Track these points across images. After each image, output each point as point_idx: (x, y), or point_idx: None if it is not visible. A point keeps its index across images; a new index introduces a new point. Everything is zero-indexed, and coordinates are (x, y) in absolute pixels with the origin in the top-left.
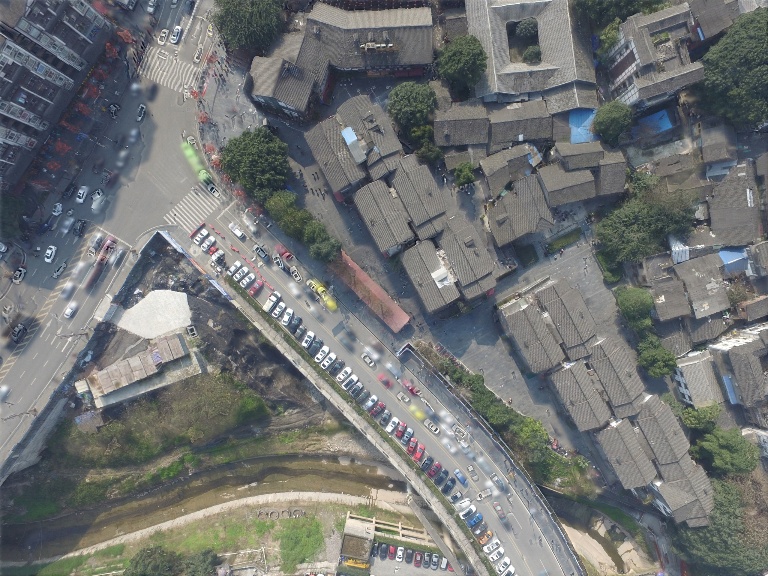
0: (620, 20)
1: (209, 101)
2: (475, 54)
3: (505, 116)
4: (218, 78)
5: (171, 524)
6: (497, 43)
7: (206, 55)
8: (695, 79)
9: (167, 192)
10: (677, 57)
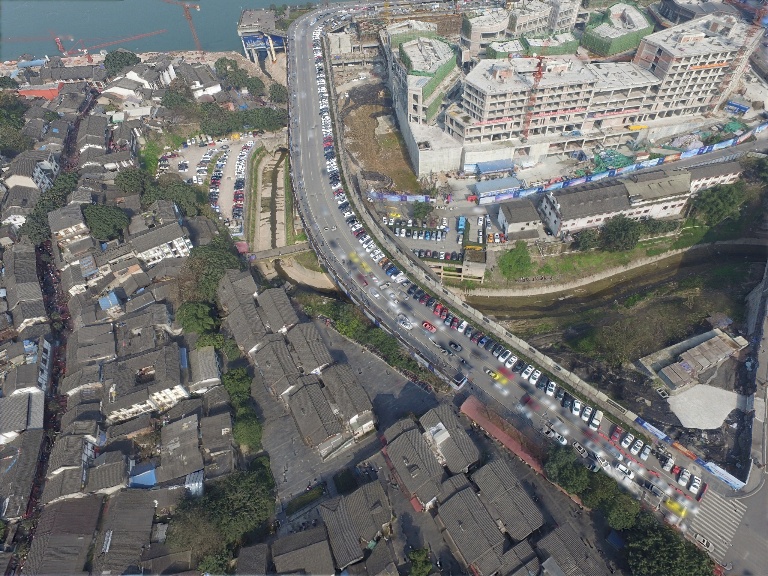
0: None
1: None
2: None
3: None
4: None
5: (617, 270)
6: None
7: None
8: None
9: (759, 539)
10: None
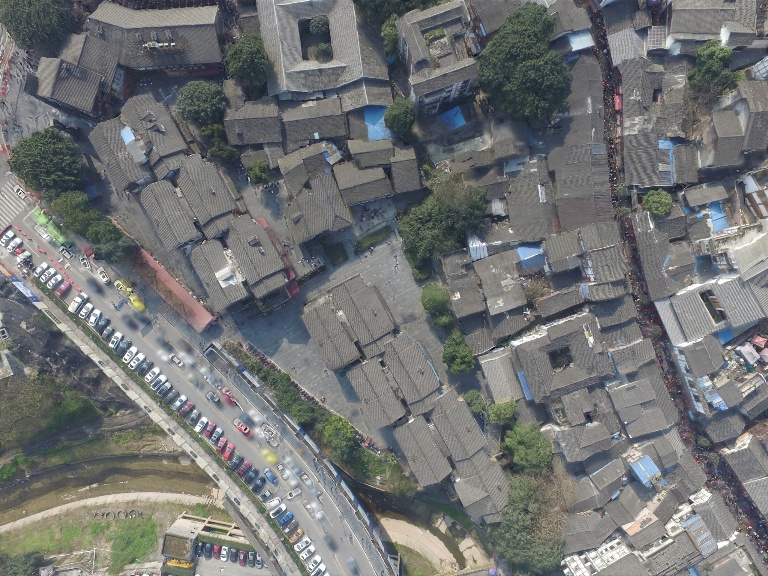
0: (396, 17)
1: (12, 102)
2: (252, 52)
3: (298, 114)
4: (21, 79)
5: (10, 526)
6: (287, 41)
7: (7, 56)
8: (470, 75)
9: None
10: (453, 53)
